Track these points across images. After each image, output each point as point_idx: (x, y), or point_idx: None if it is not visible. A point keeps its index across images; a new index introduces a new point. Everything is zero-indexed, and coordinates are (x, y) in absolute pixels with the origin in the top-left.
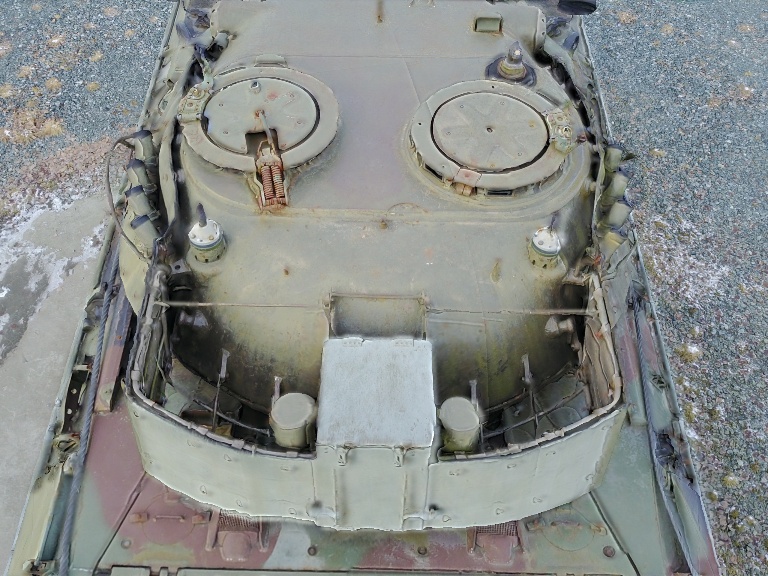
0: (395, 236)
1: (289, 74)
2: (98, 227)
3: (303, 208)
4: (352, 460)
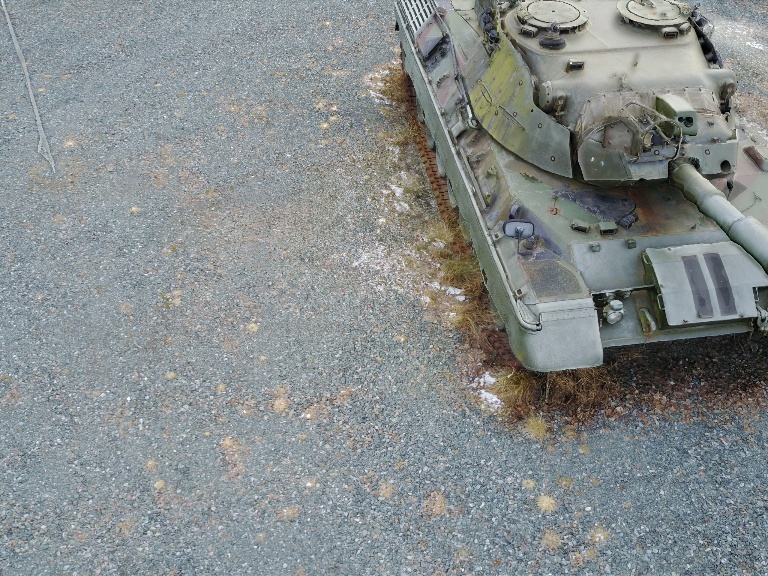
0: (574, 0)
1: (656, 23)
2: None
3: (614, 0)
4: None
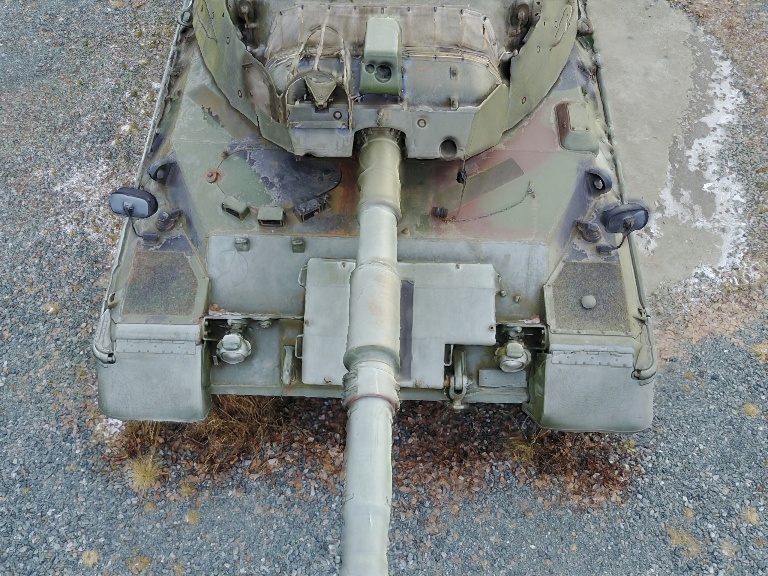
0: None
1: None
2: (654, 246)
3: None
4: None
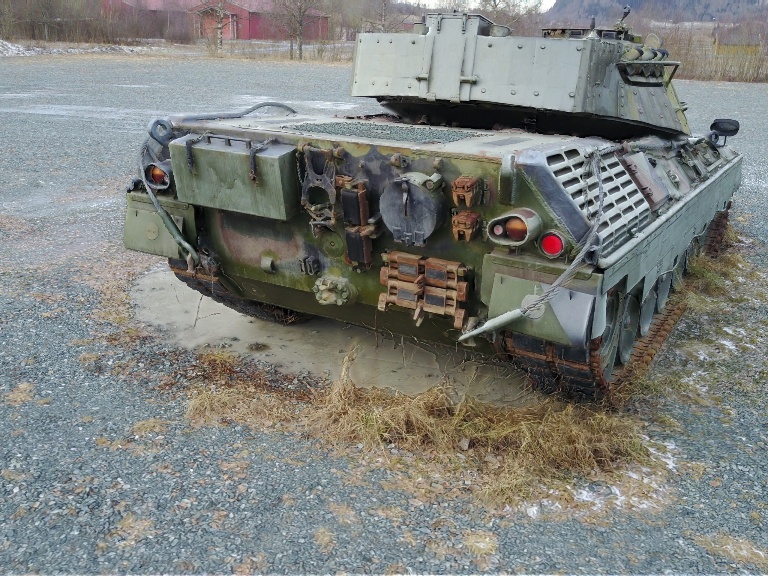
0: None
1: None
2: None
3: None
4: (443, 27)
